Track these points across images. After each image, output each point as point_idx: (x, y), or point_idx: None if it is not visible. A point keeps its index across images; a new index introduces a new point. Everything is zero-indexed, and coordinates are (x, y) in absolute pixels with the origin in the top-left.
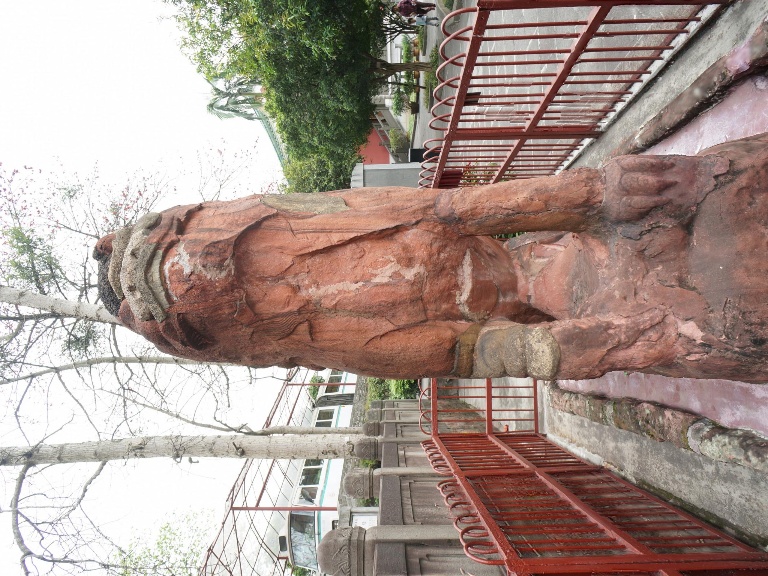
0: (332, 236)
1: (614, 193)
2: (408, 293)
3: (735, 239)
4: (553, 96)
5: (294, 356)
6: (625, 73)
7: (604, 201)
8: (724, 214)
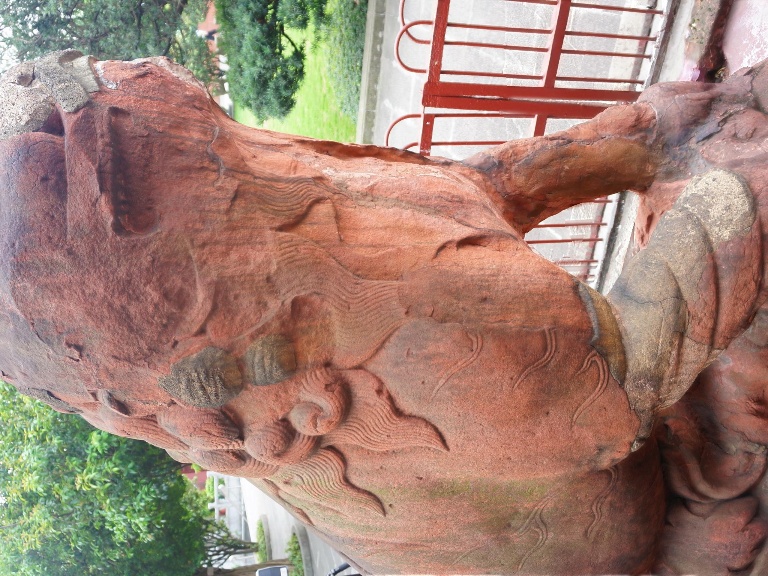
0: None
1: (662, 98)
2: (475, 196)
3: None
4: None
5: (302, 293)
6: (583, 223)
7: (657, 112)
8: None
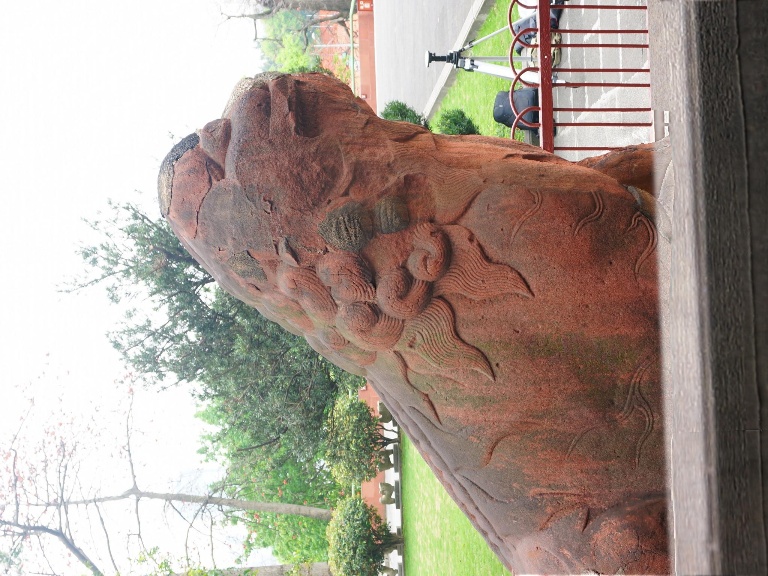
0: None
1: None
2: None
3: None
4: None
5: (411, 173)
6: None
7: None
8: None
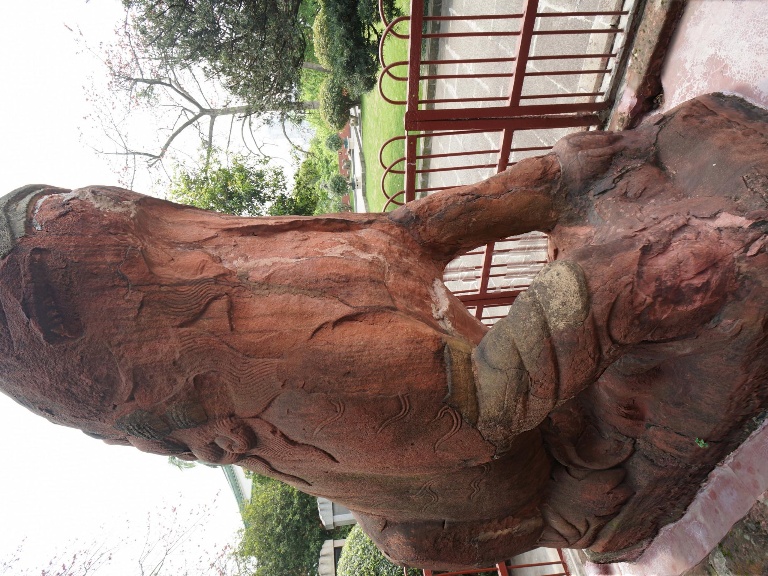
0: (269, 221)
1: (568, 153)
2: (366, 270)
3: (709, 141)
4: None
5: (202, 372)
6: None
7: (562, 166)
8: (683, 132)
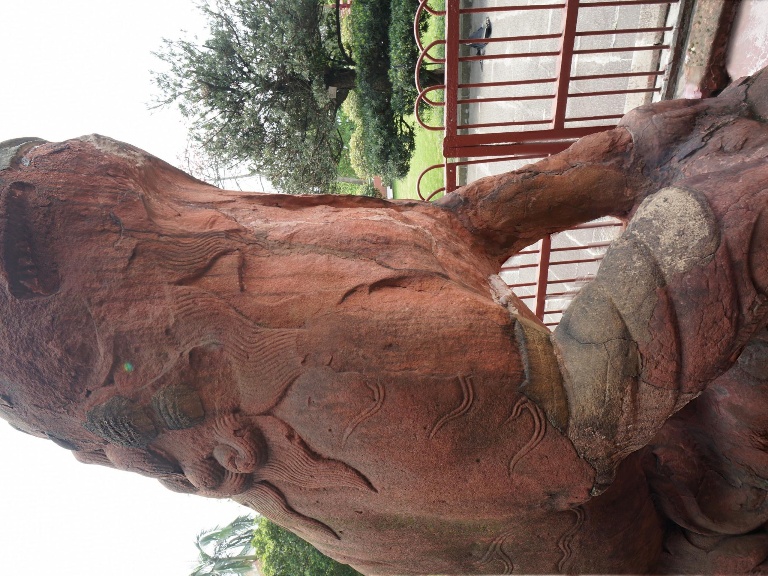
0: None
1: (639, 120)
2: (409, 236)
3: None
4: (545, 282)
5: (201, 344)
6: (604, 244)
7: (633, 135)
8: None
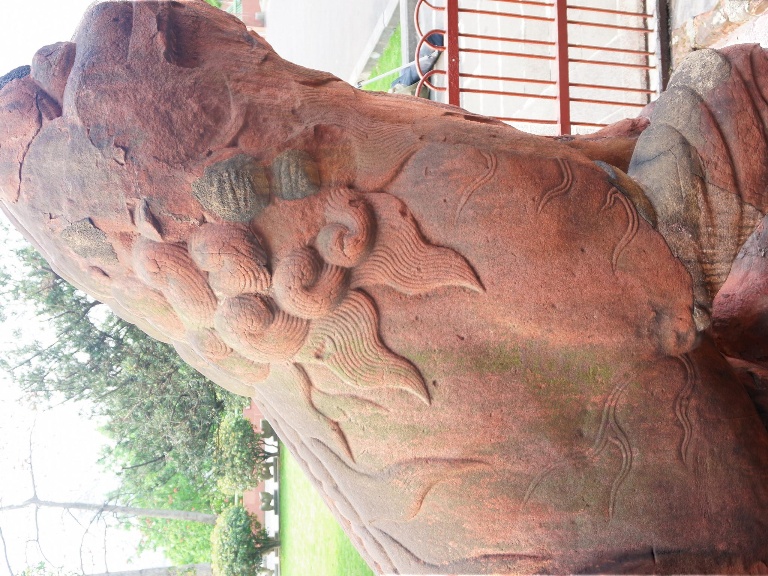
0: None
1: (651, 108)
2: None
3: None
4: None
5: (324, 124)
6: None
7: (650, 118)
8: None
